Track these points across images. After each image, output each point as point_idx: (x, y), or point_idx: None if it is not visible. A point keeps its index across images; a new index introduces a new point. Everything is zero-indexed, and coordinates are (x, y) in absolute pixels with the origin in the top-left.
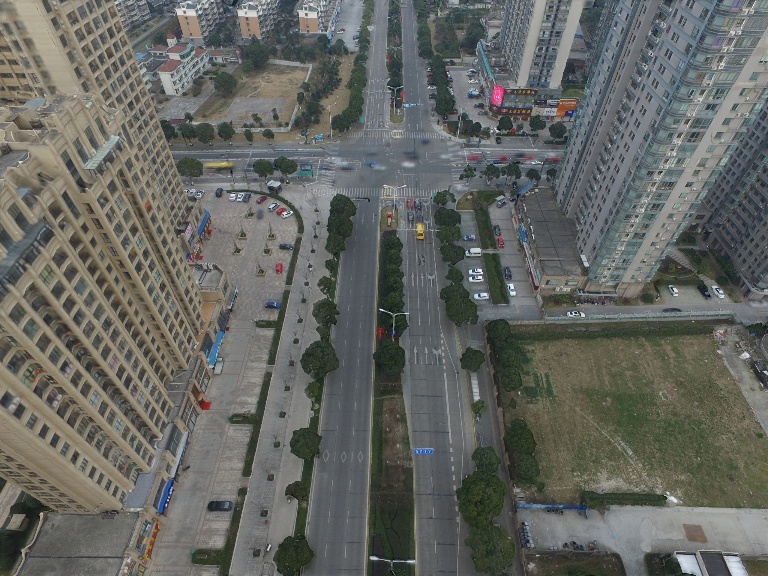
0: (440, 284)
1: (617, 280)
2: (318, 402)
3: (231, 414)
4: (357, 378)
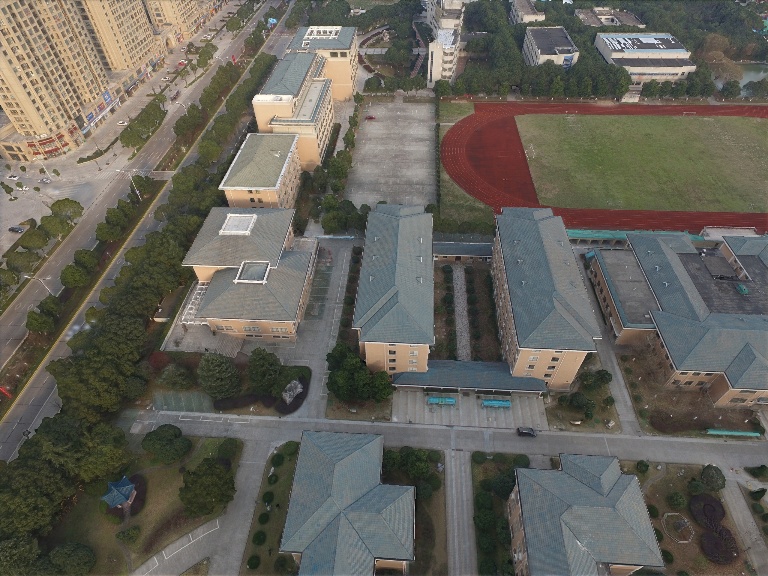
0: None
1: None
2: (262, 4)
3: None
4: (276, 1)
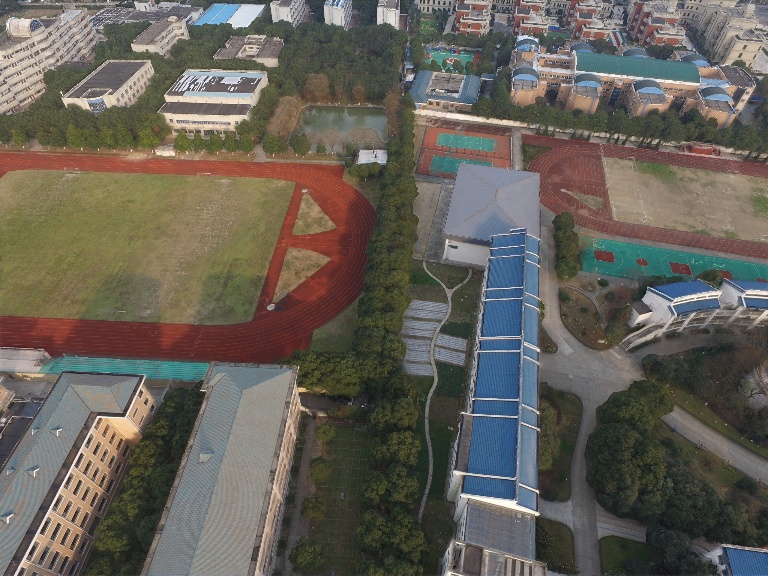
0: (18, 0)
1: None
2: None
3: None
4: None
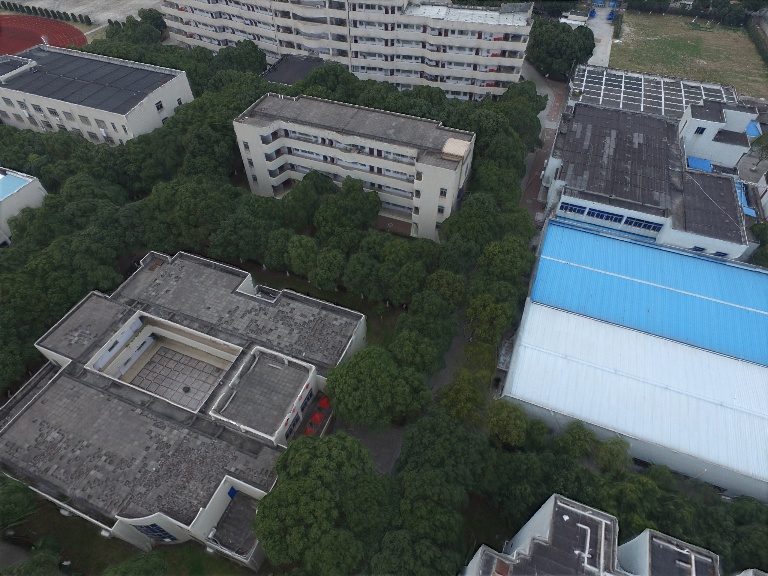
0: None
1: None
2: None
3: None
4: None
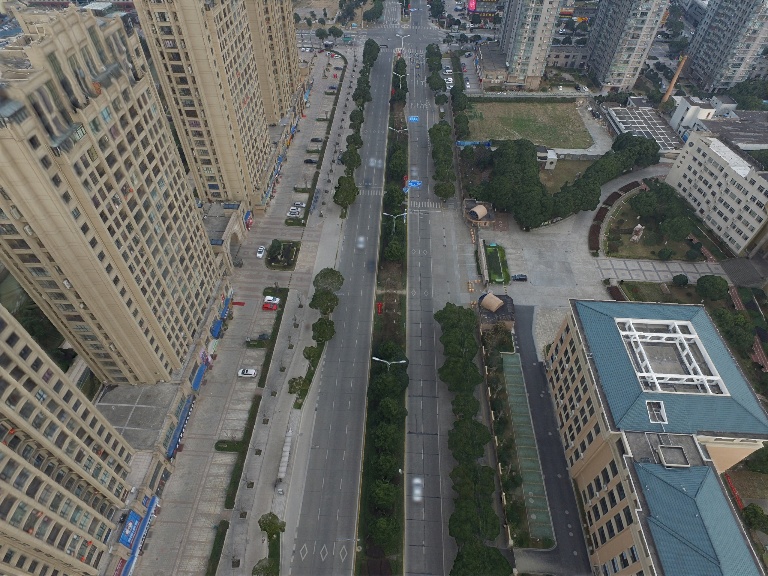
0: (427, 84)
1: (524, 74)
2: None
3: (317, 118)
4: (381, 111)
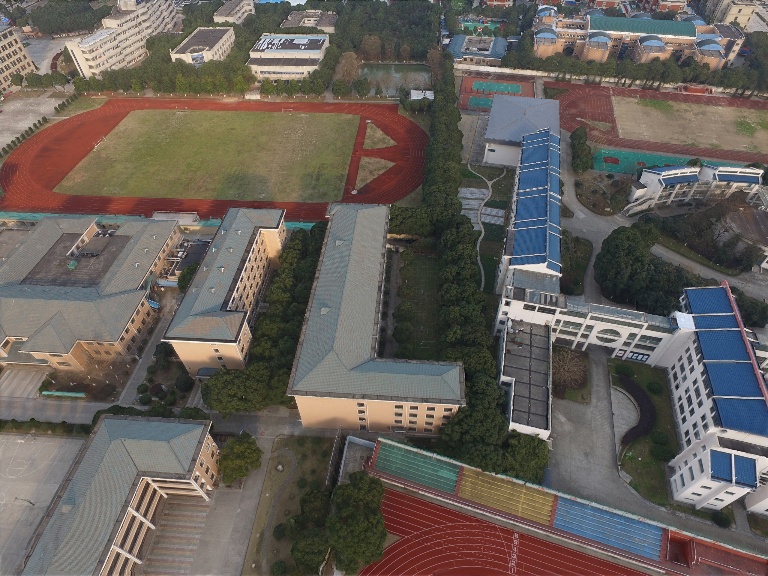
0: None
1: None
2: (34, 3)
3: None
4: None
